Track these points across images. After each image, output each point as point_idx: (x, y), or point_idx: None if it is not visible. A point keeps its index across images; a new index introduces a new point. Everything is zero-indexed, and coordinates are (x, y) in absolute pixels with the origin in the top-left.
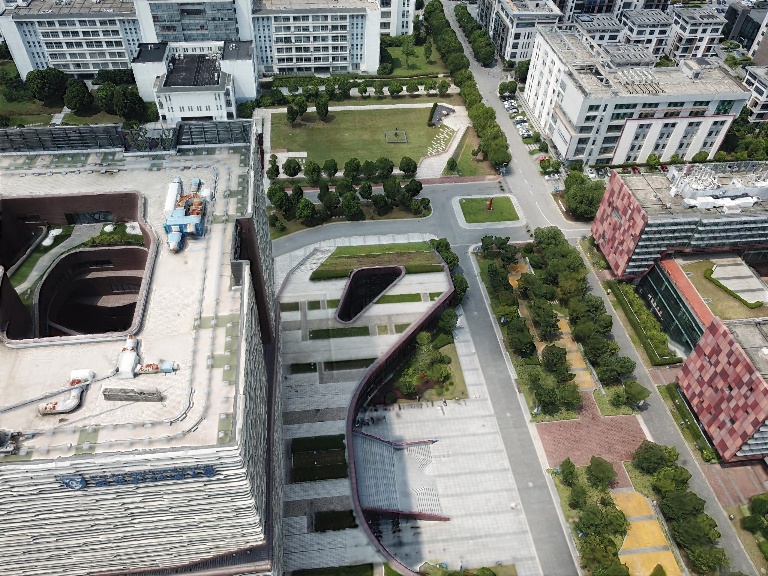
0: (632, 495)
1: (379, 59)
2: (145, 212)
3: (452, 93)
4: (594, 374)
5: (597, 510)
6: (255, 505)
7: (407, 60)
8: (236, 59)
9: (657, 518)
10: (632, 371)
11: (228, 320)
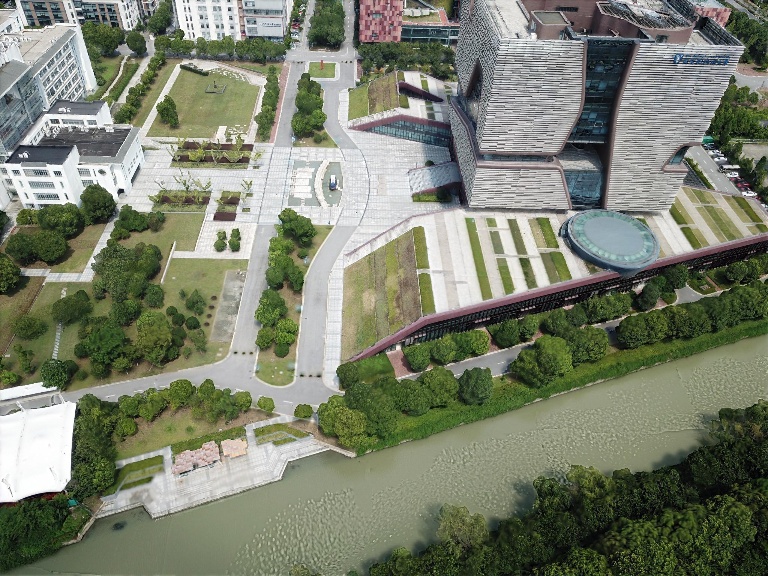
0: None
1: (93, 72)
2: None
3: None
4: None
5: None
6: None
7: None
8: (95, 109)
9: None
10: None
11: None
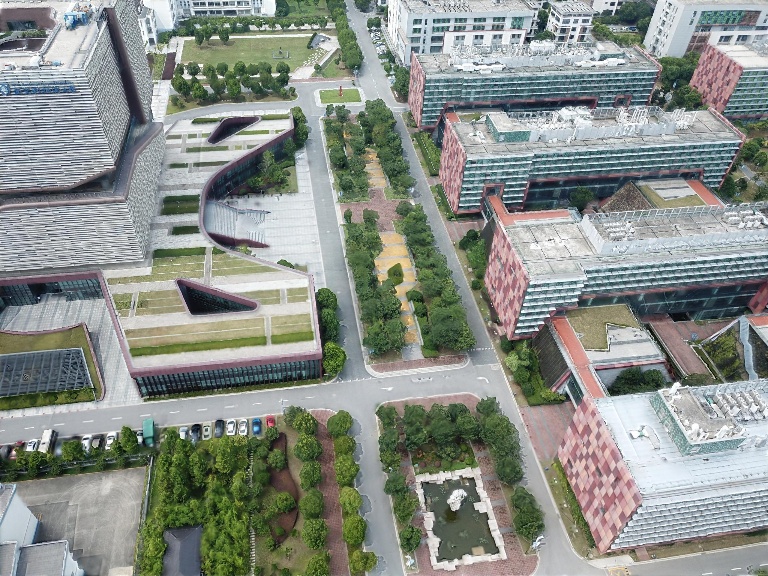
0: (393, 234)
1: (275, 4)
2: (55, 16)
3: (332, 28)
4: (387, 179)
5: (359, 229)
6: (104, 130)
7: (299, 6)
8: None
9: (405, 244)
10: (407, 170)
11: None
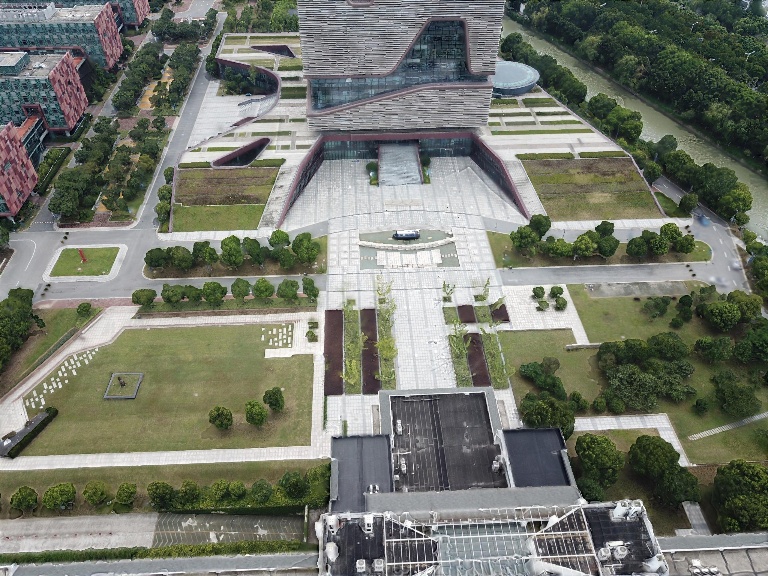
0: None
1: None
2: None
3: None
4: None
5: (171, 85)
6: None
7: None
8: (363, 447)
9: None
10: None
11: None
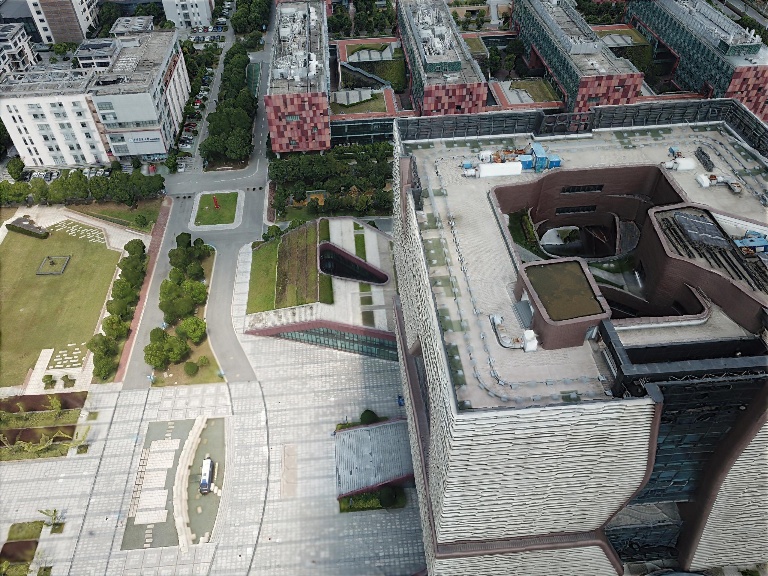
0: None
1: None
2: None
3: None
4: None
5: None
6: None
7: None
8: None
9: None
10: None
11: (621, 136)
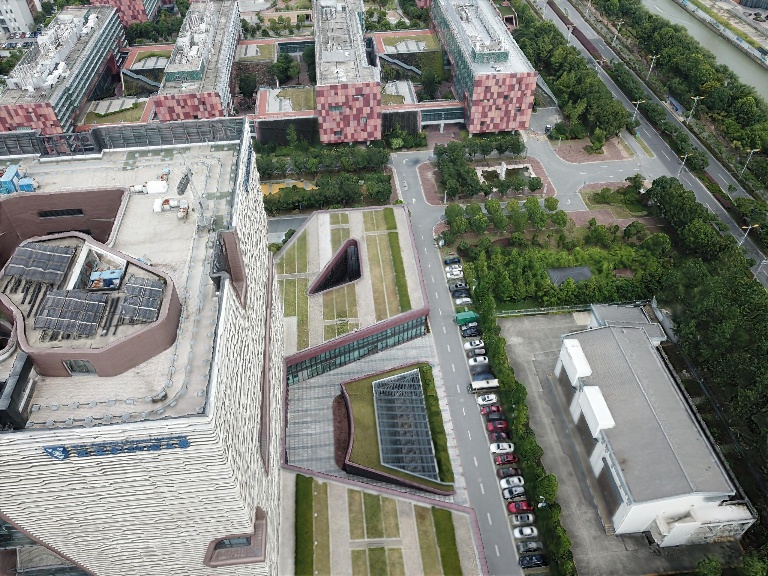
0: None
1: None
2: None
3: None
4: None
5: None
6: None
7: None
8: None
9: None
10: None
11: (132, 156)
